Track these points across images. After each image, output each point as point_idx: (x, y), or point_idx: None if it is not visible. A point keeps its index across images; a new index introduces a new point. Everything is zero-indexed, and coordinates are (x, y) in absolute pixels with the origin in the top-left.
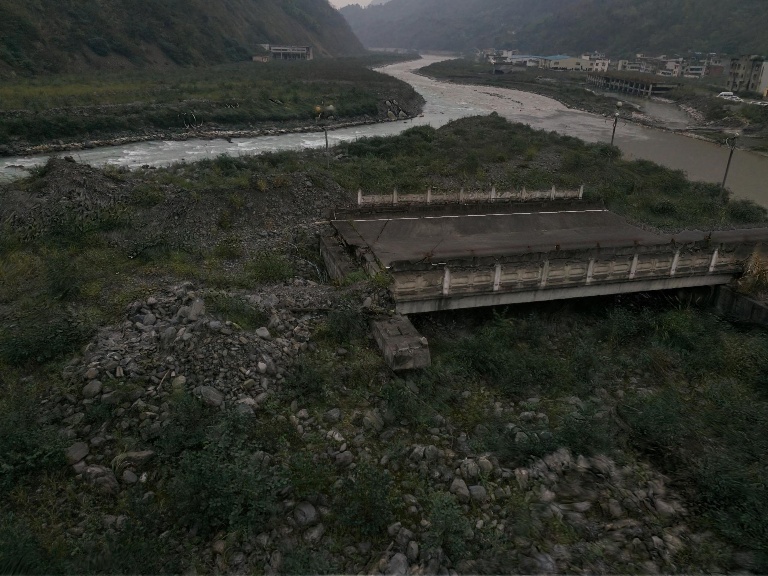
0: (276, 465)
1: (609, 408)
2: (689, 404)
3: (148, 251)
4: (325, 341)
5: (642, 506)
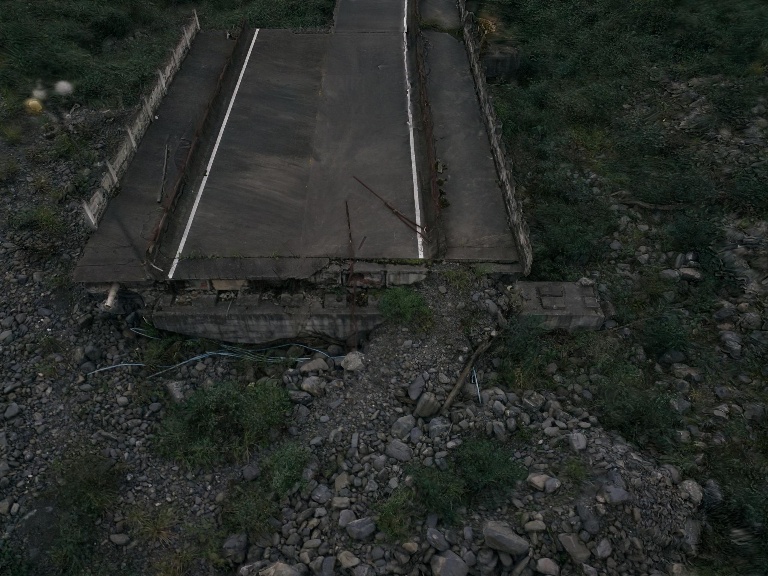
0: (766, 479)
1: (623, 206)
2: (605, 162)
3: None
4: (532, 381)
5: (761, 240)
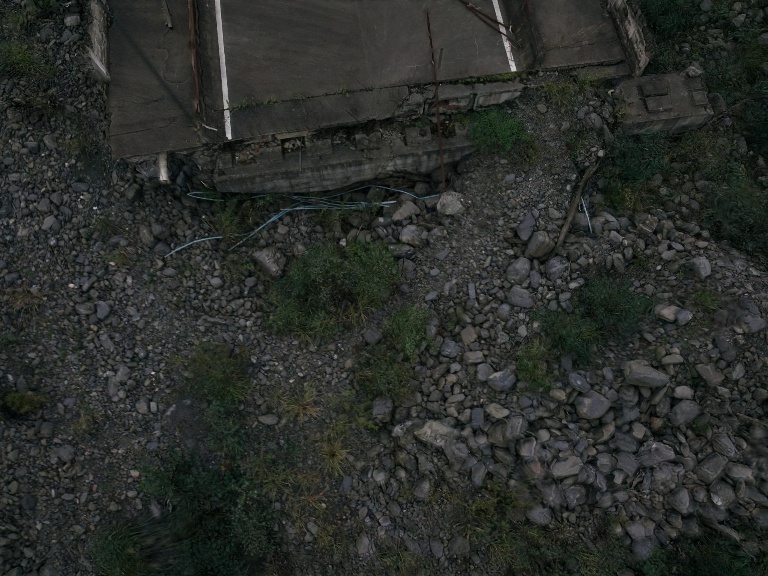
0: None
1: None
2: None
3: (182, 567)
4: None
5: None
